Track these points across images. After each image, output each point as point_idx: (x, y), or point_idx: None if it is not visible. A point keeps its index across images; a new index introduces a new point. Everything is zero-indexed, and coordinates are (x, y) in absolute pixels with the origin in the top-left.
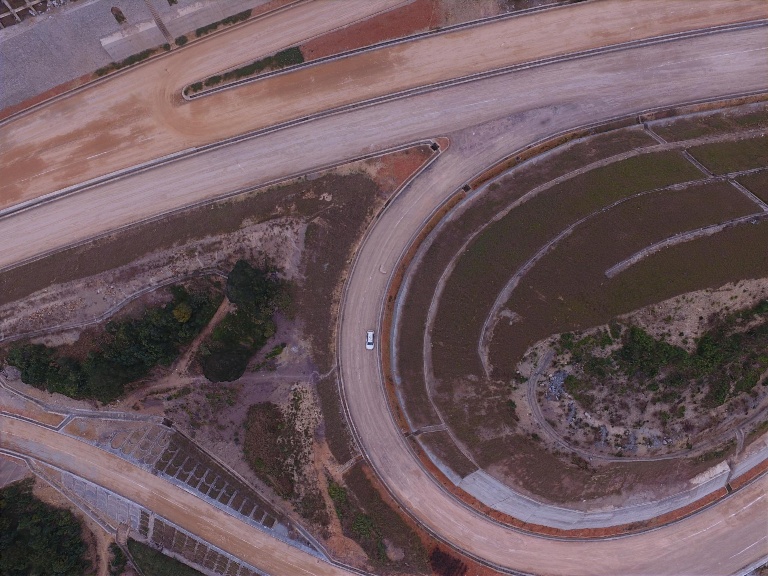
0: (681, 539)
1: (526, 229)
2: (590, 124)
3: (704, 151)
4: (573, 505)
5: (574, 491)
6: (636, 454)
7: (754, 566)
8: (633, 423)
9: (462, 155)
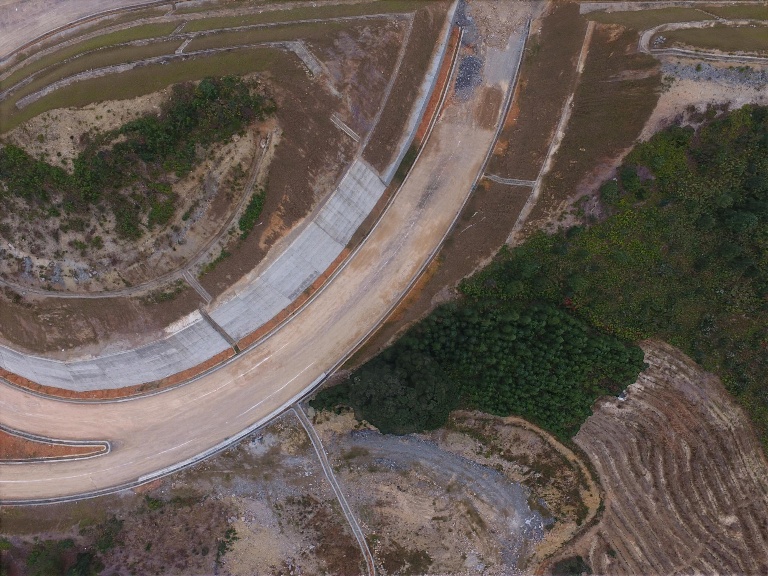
0: (192, 400)
1: (6, 82)
2: (130, 6)
3: (197, 22)
4: (53, 355)
5: (39, 336)
6: (68, 288)
7: (257, 424)
8: (53, 253)
9: (4, 29)
